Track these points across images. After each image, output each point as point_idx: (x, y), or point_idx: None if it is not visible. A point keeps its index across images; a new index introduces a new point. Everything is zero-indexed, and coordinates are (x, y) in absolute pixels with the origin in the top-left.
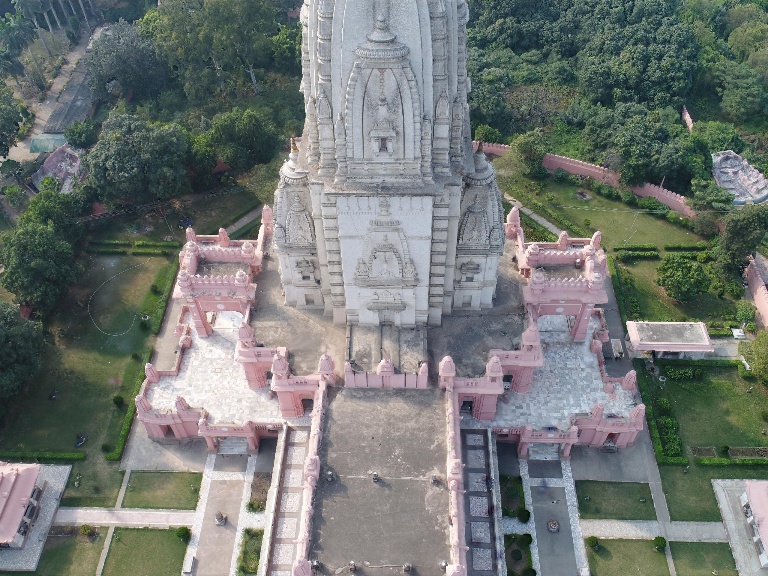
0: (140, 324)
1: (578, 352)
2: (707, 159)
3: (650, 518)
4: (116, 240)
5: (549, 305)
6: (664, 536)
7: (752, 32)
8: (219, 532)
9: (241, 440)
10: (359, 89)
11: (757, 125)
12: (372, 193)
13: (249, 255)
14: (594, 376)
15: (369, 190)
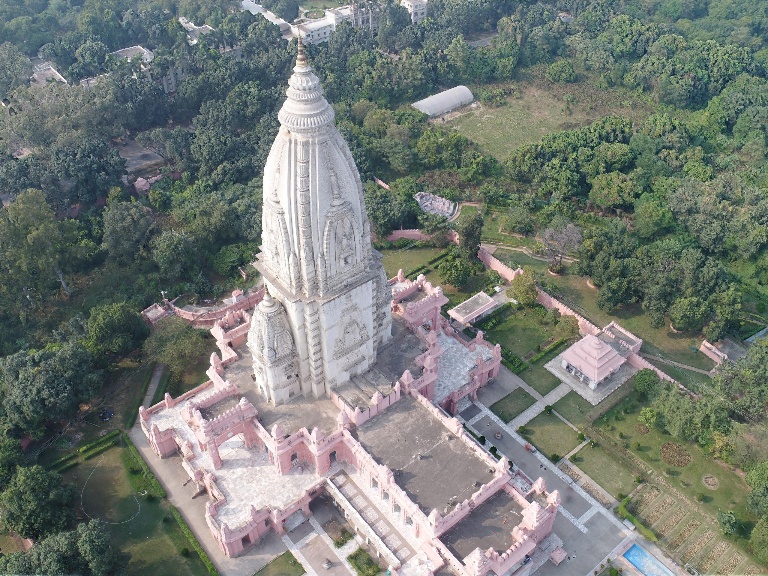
0: (148, 498)
1: (442, 340)
2: None
3: (534, 402)
4: (60, 458)
5: (419, 320)
6: None
7: (378, 117)
8: (333, 572)
9: (295, 515)
10: (333, 235)
11: (417, 171)
12: (346, 292)
13: (233, 388)
14: (460, 347)
15: (343, 291)
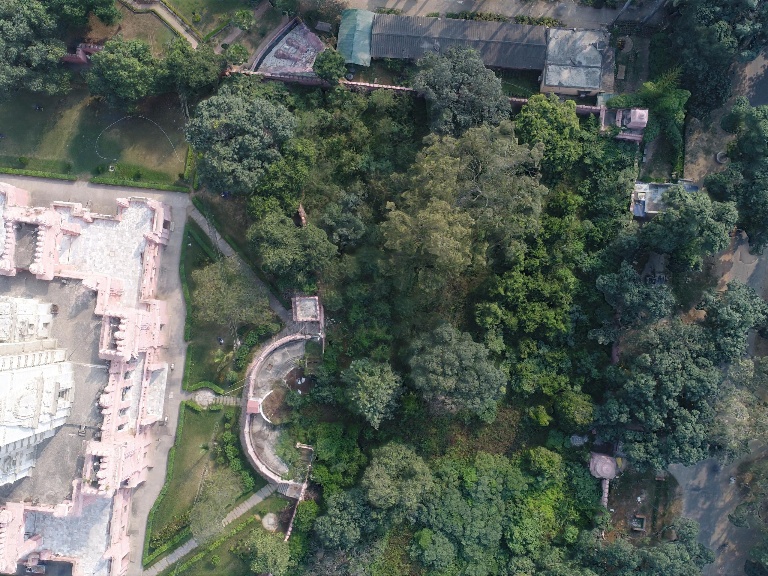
0: (98, 166)
1: None
2: None
3: None
4: None
5: None
6: None
7: None
8: None
9: None
10: None
11: None
12: None
13: None
14: None
15: None
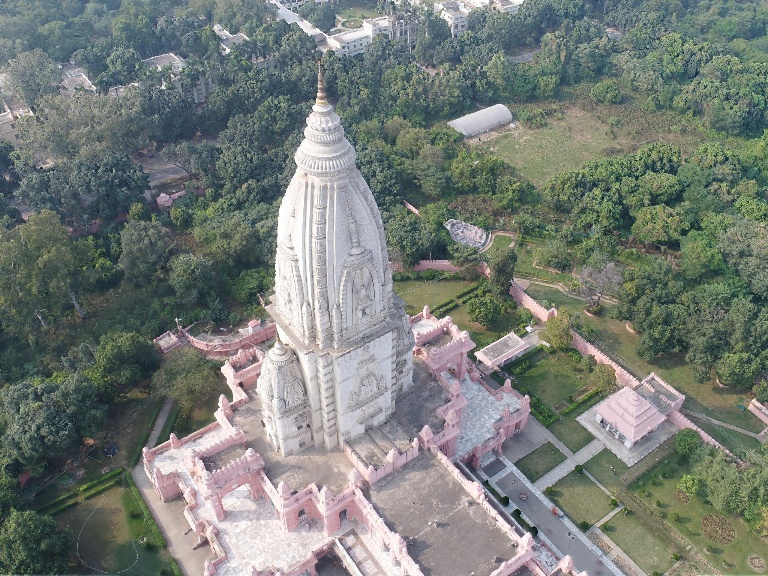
0: (146, 547)
1: (467, 386)
2: None
3: (564, 459)
4: (60, 497)
5: None
6: (577, 464)
7: (411, 137)
8: None
9: (300, 575)
10: (350, 285)
11: (449, 195)
12: (363, 344)
13: (240, 436)
14: (486, 395)
15: (360, 343)
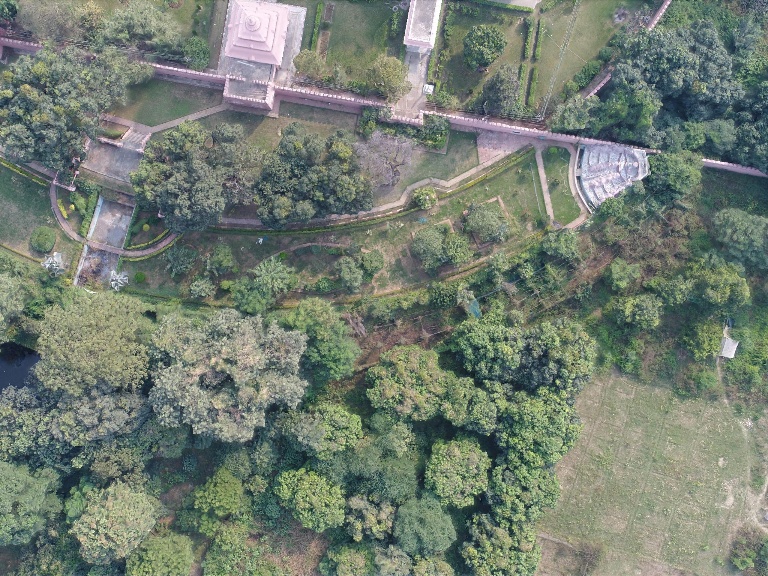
0: None
1: None
2: (630, 130)
3: None
4: None
5: None
6: None
7: None
8: None
9: None
10: None
11: (705, 248)
12: None
13: None
14: None
15: None
